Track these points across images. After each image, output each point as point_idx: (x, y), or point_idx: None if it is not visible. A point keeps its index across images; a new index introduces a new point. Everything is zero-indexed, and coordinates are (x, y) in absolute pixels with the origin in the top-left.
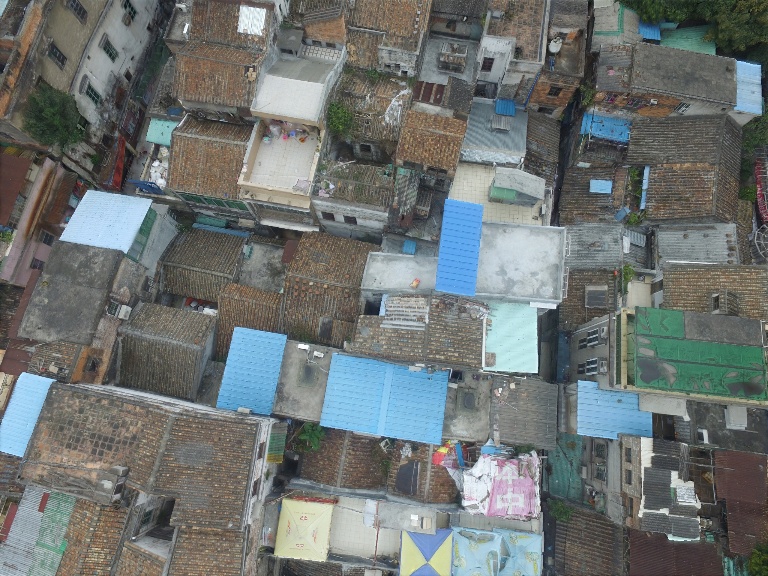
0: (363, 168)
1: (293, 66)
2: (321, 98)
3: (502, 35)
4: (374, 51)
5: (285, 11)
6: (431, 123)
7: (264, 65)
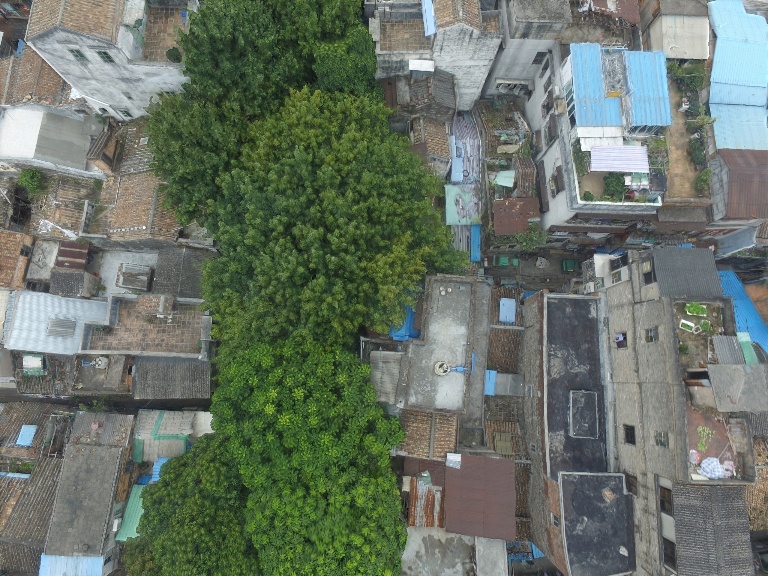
0: (1, 211)
1: (72, 134)
2: (8, 157)
3: (131, 315)
4: (109, 201)
5: (118, 116)
6: (1, 254)
7: (46, 107)
